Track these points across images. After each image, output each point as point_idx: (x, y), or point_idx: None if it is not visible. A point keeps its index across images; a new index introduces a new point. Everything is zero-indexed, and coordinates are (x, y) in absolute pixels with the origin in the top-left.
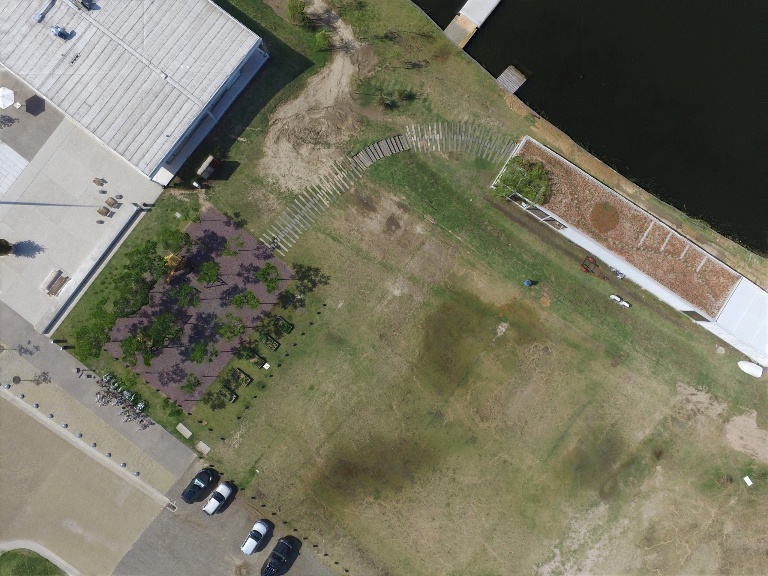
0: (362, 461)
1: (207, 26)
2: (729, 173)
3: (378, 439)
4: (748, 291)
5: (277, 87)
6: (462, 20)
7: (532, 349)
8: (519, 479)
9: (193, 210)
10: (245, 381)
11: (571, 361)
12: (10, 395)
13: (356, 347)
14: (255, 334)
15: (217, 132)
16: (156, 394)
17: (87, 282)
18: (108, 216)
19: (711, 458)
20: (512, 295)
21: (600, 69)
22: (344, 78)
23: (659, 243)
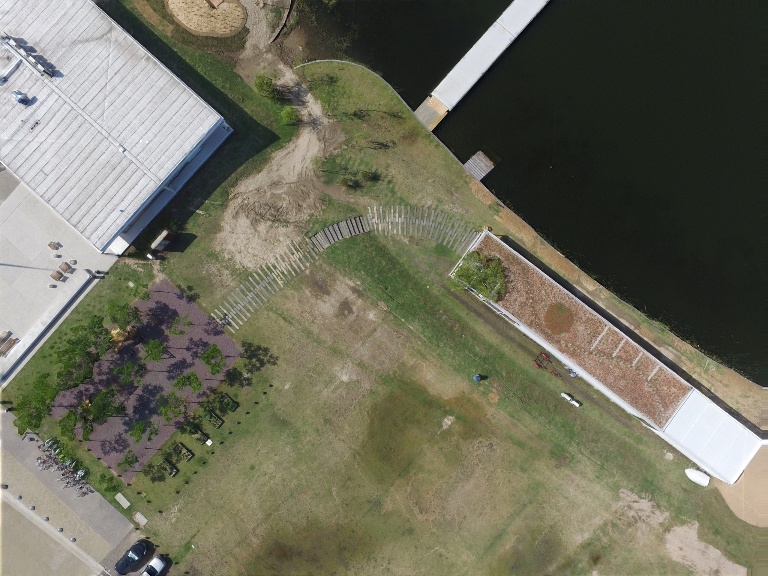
0: (298, 544)
1: (169, 101)
2: (693, 275)
3: (315, 523)
4: (699, 403)
5: (239, 161)
6: (433, 102)
7: (476, 445)
8: (454, 574)
9: None
10: (186, 456)
11: (515, 459)
12: None
13: (300, 430)
14: (200, 410)
15: (176, 204)
16: (97, 462)
17: (36, 345)
18: (61, 281)
19: (649, 567)
20: (460, 389)
21: (570, 160)
22: (309, 154)
23: (612, 349)
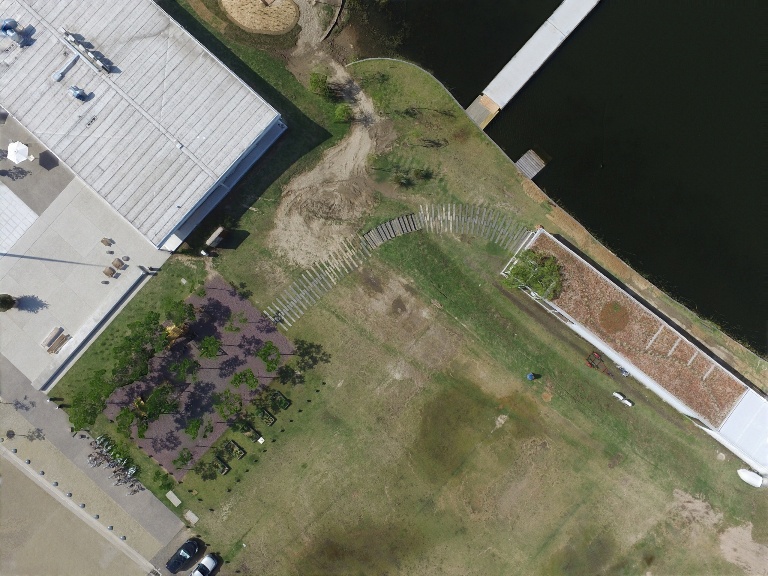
0: (350, 543)
1: (226, 98)
2: (744, 275)
3: (368, 523)
4: (754, 403)
5: (293, 158)
6: (485, 100)
7: (530, 444)
8: (507, 574)
9: (199, 283)
10: (238, 454)
11: (568, 459)
12: (3, 449)
13: (352, 428)
14: (252, 407)
15: (229, 200)
16: (148, 460)
17: (88, 342)
18: (113, 277)
19: (703, 568)
20: (514, 387)
21: (621, 159)
22: (361, 152)
23: (667, 348)
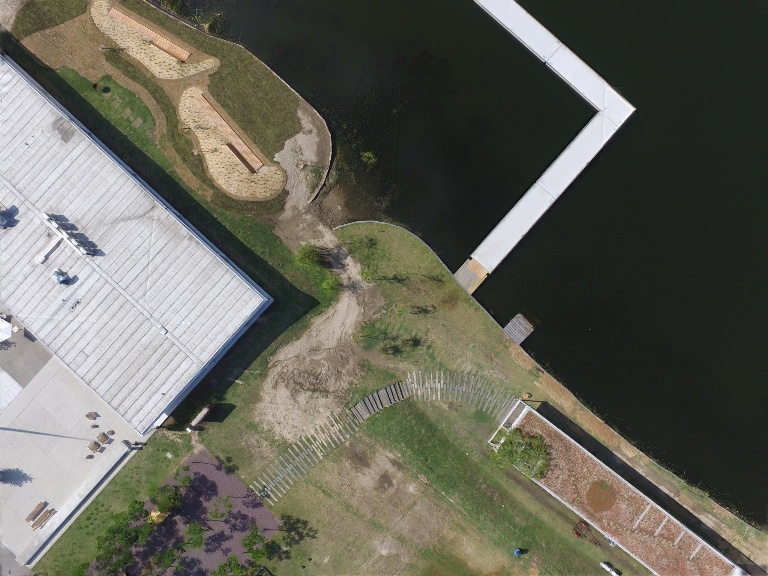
0: None
1: (212, 282)
2: (732, 439)
3: None
4: None
5: (279, 330)
6: (473, 265)
7: None
8: None
9: None
10: None
11: None
12: None
13: None
14: None
15: (215, 374)
16: None
17: (72, 516)
18: (98, 451)
19: None
20: (501, 563)
21: (610, 323)
22: (348, 319)
23: (654, 527)
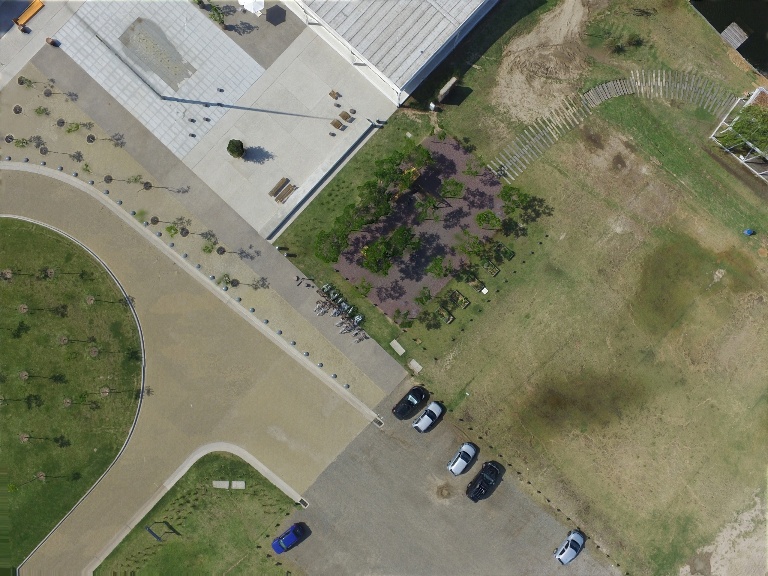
0: (572, 393)
1: None
2: None
3: (589, 373)
4: None
5: (514, 19)
6: None
7: (747, 298)
8: (725, 425)
9: (439, 126)
10: (464, 303)
11: None
12: (227, 297)
13: (574, 280)
14: (476, 258)
15: (454, 57)
16: (373, 309)
17: (314, 192)
18: (340, 129)
19: None
20: (731, 243)
21: None
22: (574, 18)
23: None
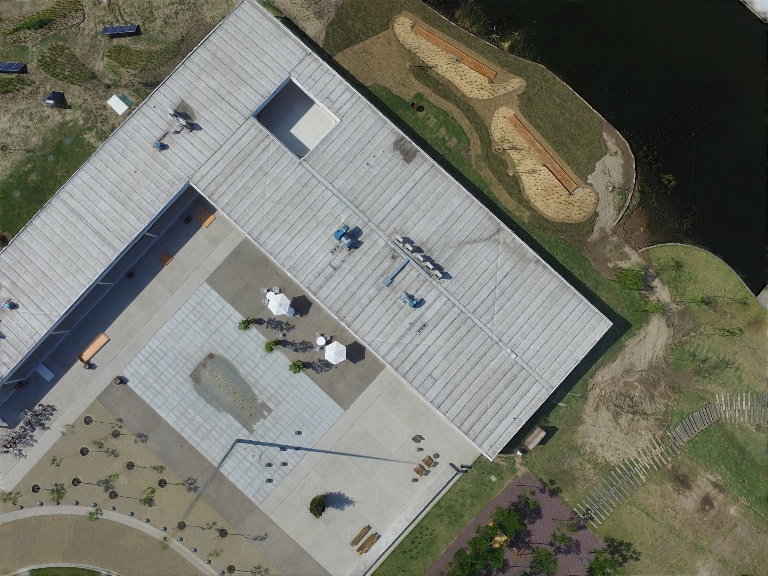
0: None
1: (559, 306)
2: None
3: None
4: None
5: (600, 353)
6: None
7: None
8: None
9: (531, 494)
10: None
11: None
12: None
13: None
14: None
15: None
16: None
17: (396, 540)
18: (423, 474)
19: None
20: None
21: None
22: (659, 341)
23: None
